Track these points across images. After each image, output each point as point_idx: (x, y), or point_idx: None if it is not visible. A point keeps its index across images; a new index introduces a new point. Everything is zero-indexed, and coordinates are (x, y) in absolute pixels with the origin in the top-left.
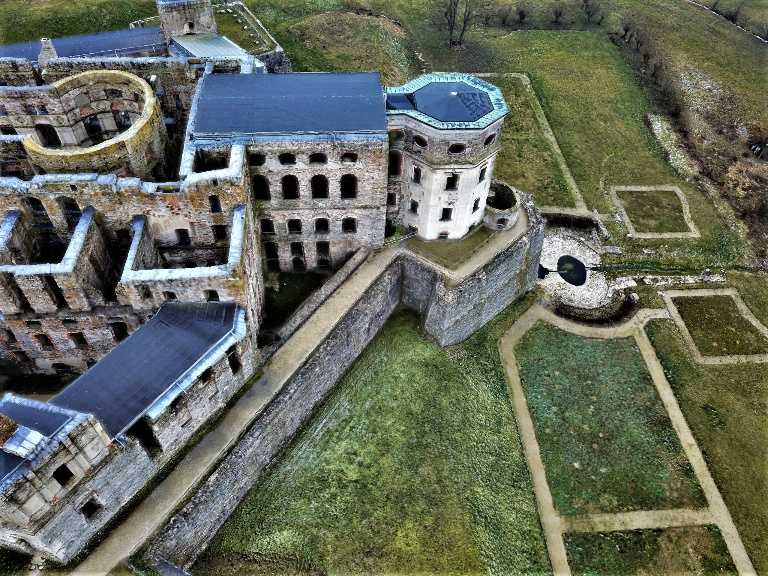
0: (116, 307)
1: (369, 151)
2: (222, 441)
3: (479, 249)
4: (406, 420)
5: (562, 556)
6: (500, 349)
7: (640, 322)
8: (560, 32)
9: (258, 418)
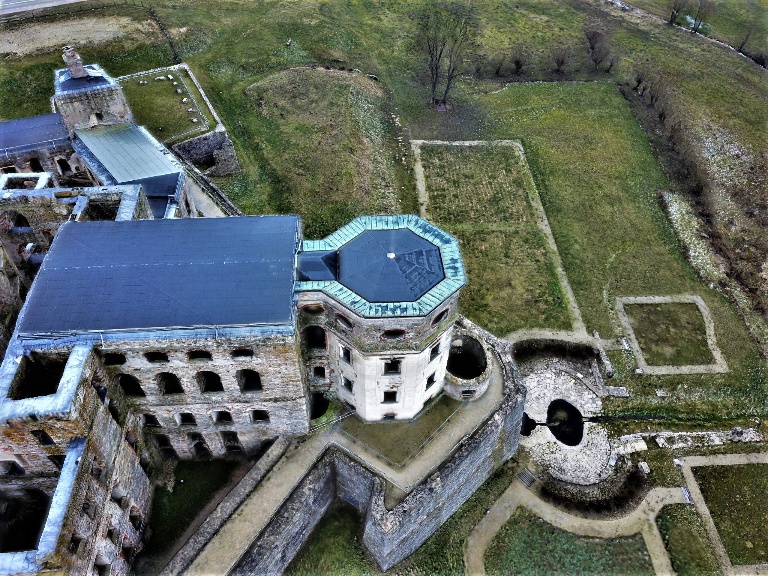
0: None
1: (267, 346)
2: None
3: (436, 433)
4: None
5: None
6: (466, 556)
7: (651, 510)
8: (562, 84)
9: None
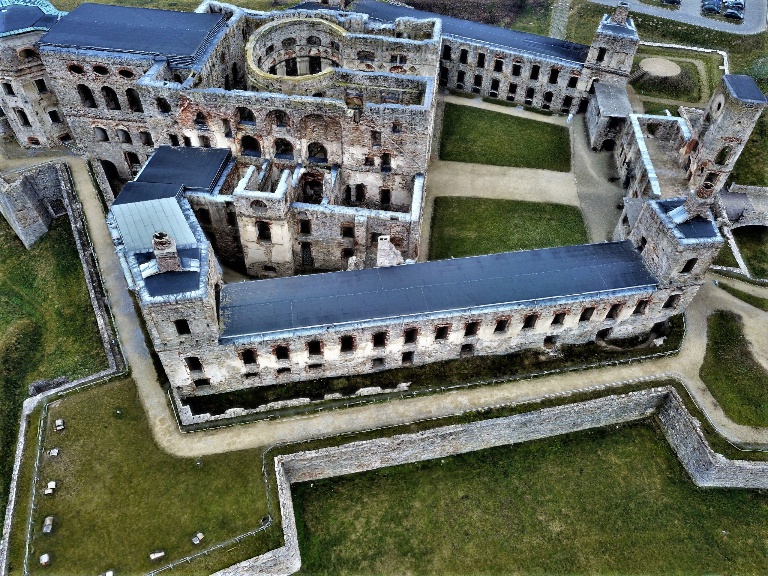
0: None
1: None
2: None
3: None
4: None
5: None
6: None
7: None
8: None
9: None
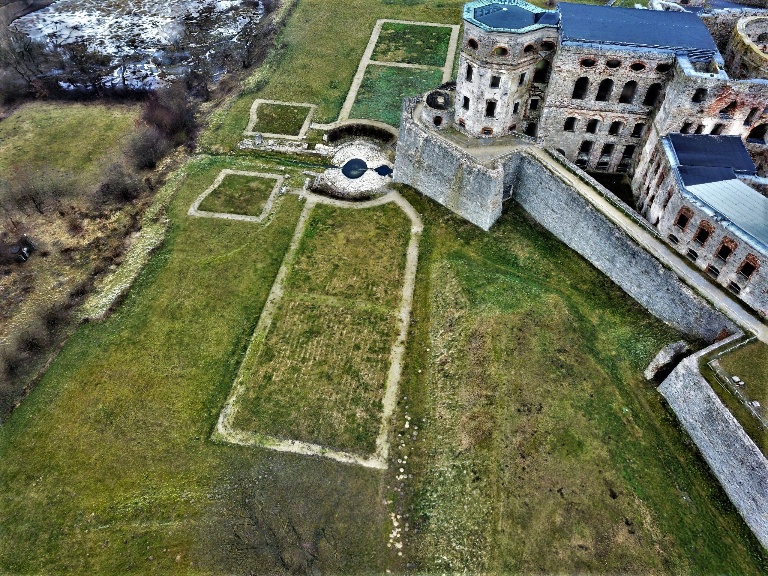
0: None
1: None
2: None
3: None
4: None
5: (448, 62)
6: None
7: (337, 124)
8: None
9: None
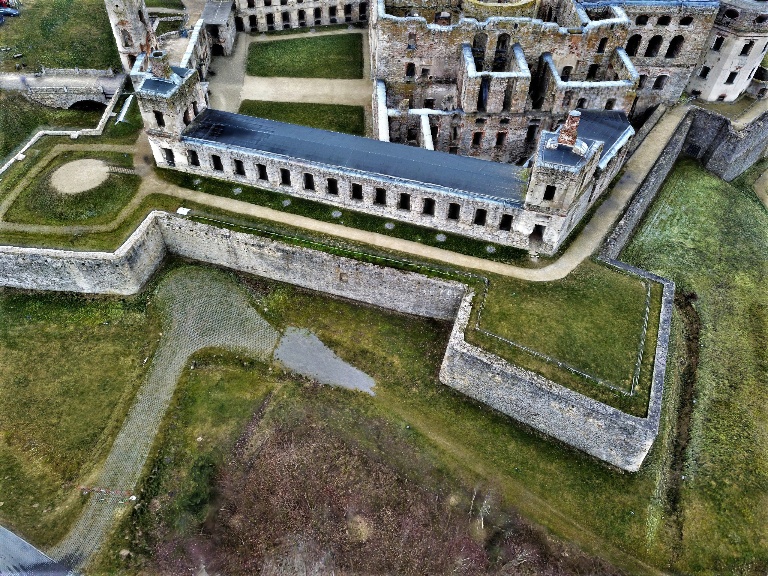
0: (539, 112)
1: (703, 16)
2: (616, 205)
3: (748, 110)
4: (715, 218)
5: None
6: (755, 191)
7: None
8: None
9: (636, 194)
